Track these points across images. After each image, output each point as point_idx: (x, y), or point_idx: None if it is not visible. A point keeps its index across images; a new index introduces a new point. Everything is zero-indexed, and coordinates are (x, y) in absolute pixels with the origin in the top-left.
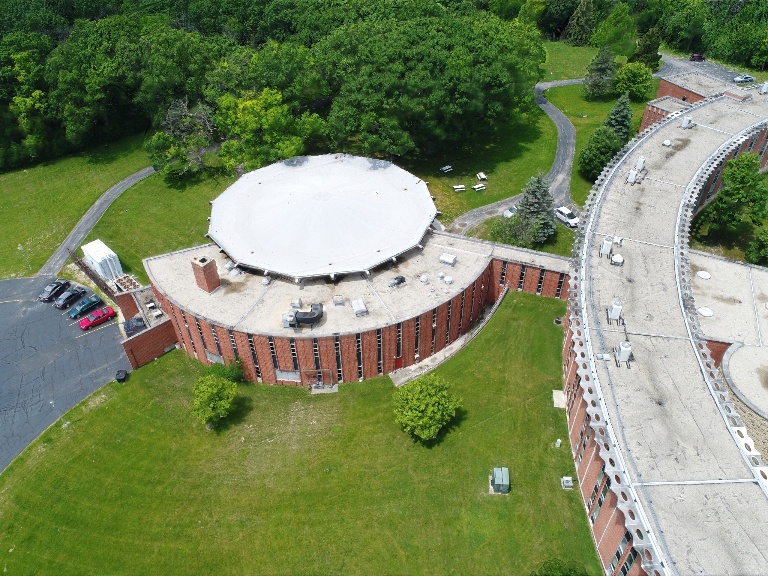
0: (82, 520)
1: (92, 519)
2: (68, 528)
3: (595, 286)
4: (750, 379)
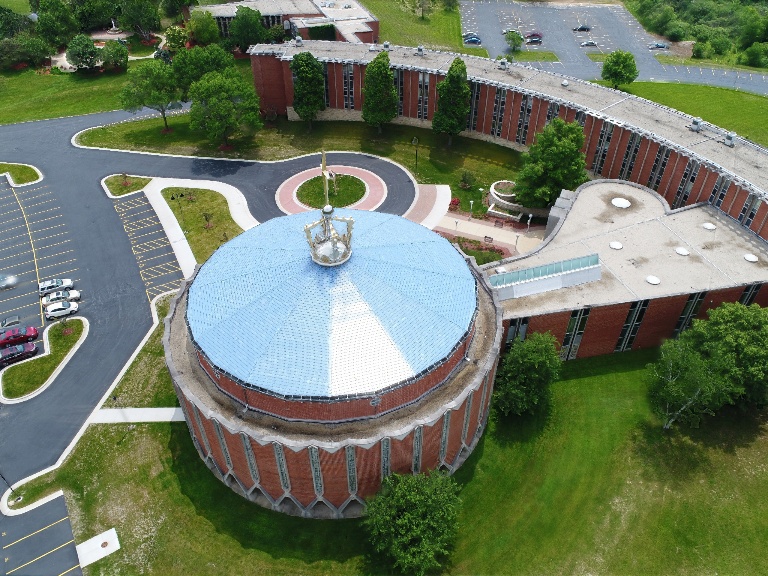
0: (762, 115)
1: (760, 116)
2: (760, 113)
3: (764, 155)
4: (641, 197)
